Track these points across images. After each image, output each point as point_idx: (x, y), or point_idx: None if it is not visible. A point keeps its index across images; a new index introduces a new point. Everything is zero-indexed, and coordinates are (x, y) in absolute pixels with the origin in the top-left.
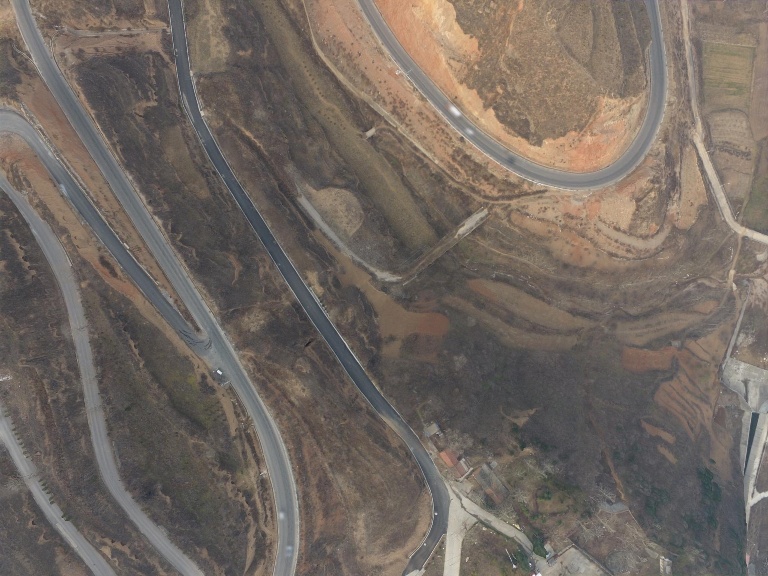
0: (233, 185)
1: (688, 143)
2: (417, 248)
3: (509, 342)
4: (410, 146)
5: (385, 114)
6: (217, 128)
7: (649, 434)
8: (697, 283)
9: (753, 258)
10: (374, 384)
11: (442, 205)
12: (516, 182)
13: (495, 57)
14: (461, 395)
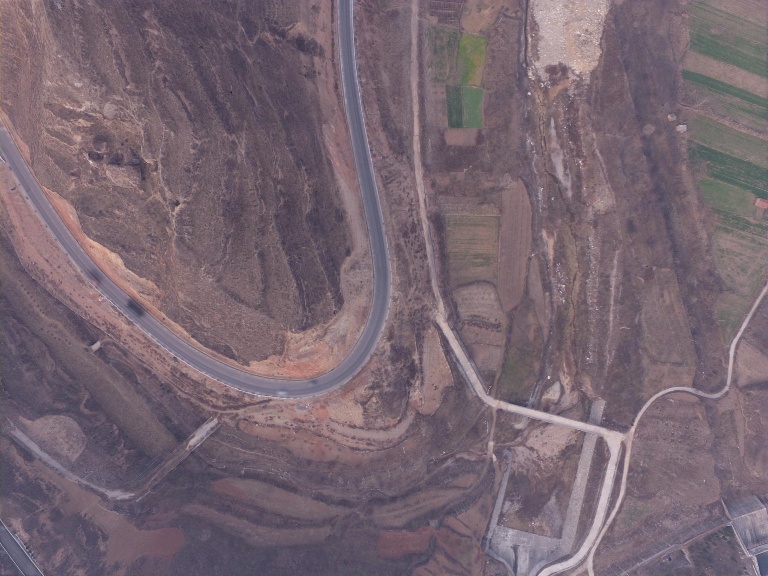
0: None
1: (430, 325)
2: (157, 456)
3: (257, 542)
4: (136, 358)
5: None
6: None
7: None
8: (455, 458)
9: (510, 429)
10: None
11: (179, 410)
12: (236, 396)
13: (174, 297)
14: None
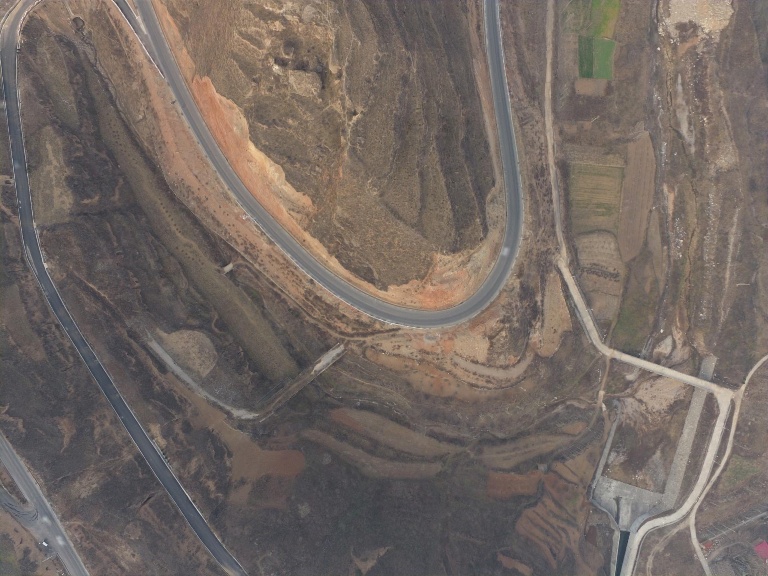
0: (76, 338)
1: (552, 269)
2: (278, 380)
3: (371, 472)
4: (267, 281)
5: (240, 252)
6: (60, 281)
7: (505, 568)
8: (566, 404)
9: (622, 379)
10: (216, 536)
11: (303, 337)
12: (368, 322)
13: (329, 214)
14: (303, 545)
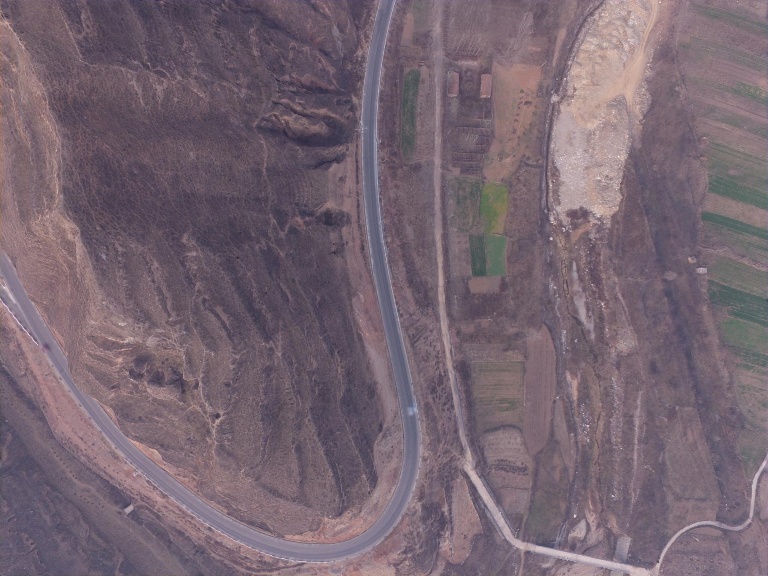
0: None
1: (458, 474)
2: None
3: None
4: (169, 521)
5: None
6: None
7: None
8: None
9: (538, 570)
10: None
11: (212, 567)
12: (271, 562)
13: (212, 486)
14: None
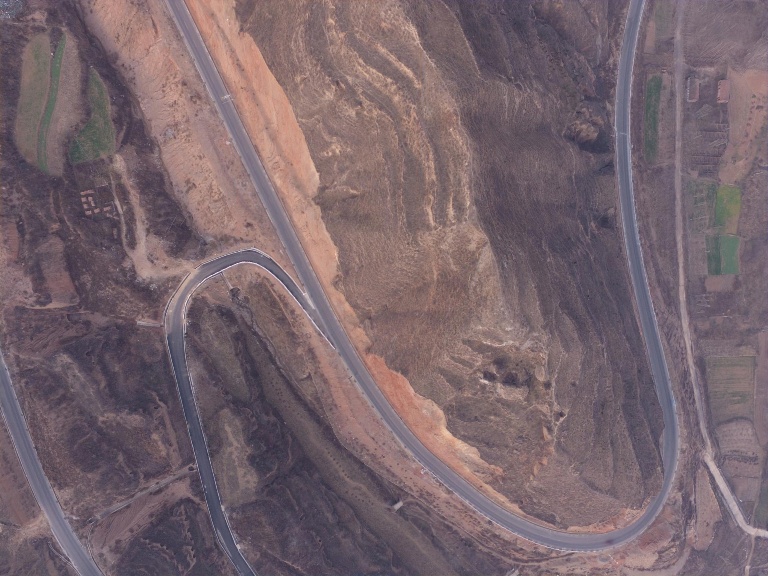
0: None
1: (700, 465)
2: None
3: None
4: (438, 516)
5: None
6: (255, 561)
7: None
8: None
9: (766, 554)
10: None
11: (473, 559)
12: (545, 552)
13: (520, 481)
14: None
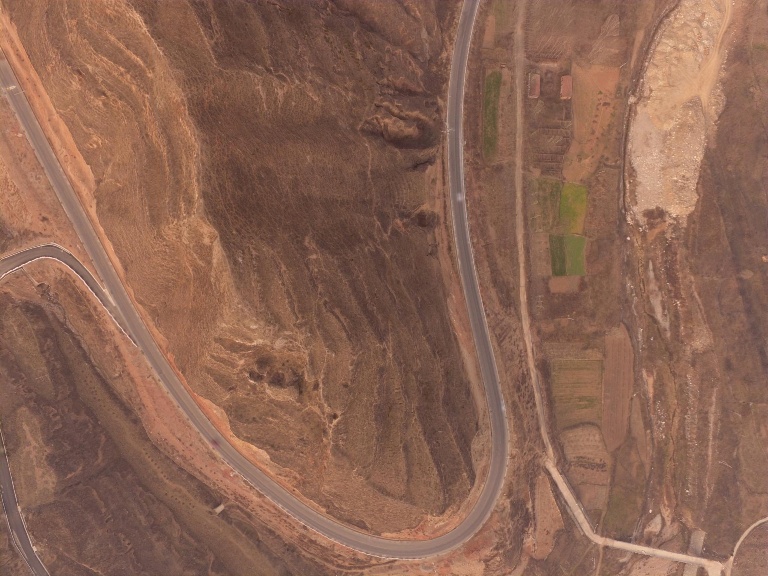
0: None
1: (540, 471)
2: None
3: None
4: (260, 520)
5: None
6: (51, 564)
7: None
8: None
9: (615, 564)
10: None
11: (301, 565)
12: (364, 559)
13: (316, 485)
14: None
